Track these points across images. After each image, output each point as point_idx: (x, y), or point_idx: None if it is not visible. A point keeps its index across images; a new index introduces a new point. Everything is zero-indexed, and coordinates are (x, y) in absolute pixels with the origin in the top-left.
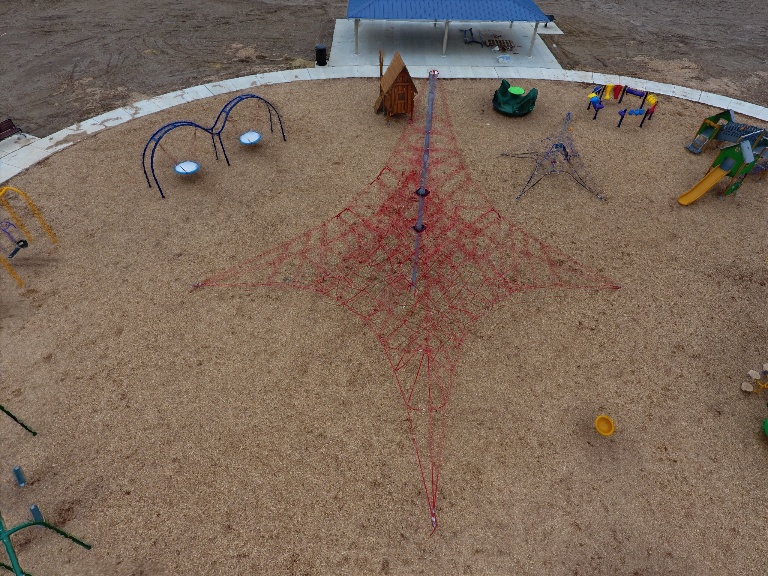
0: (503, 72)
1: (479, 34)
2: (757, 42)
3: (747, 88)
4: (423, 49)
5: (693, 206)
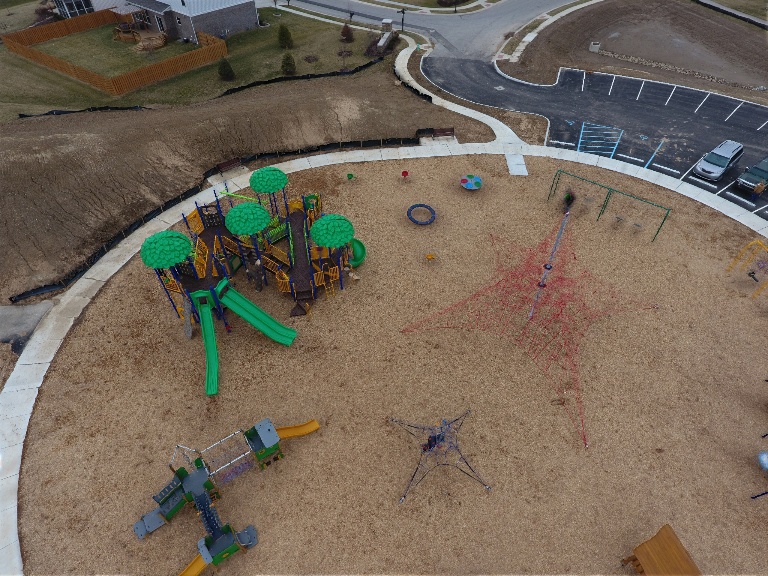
0: None
1: None
2: None
3: None
4: None
5: None
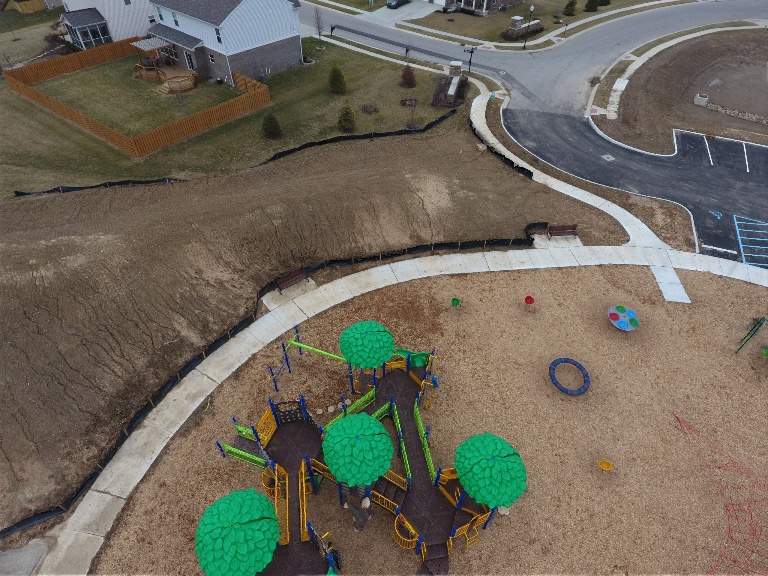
0: None
1: None
2: None
3: None
4: None
5: None
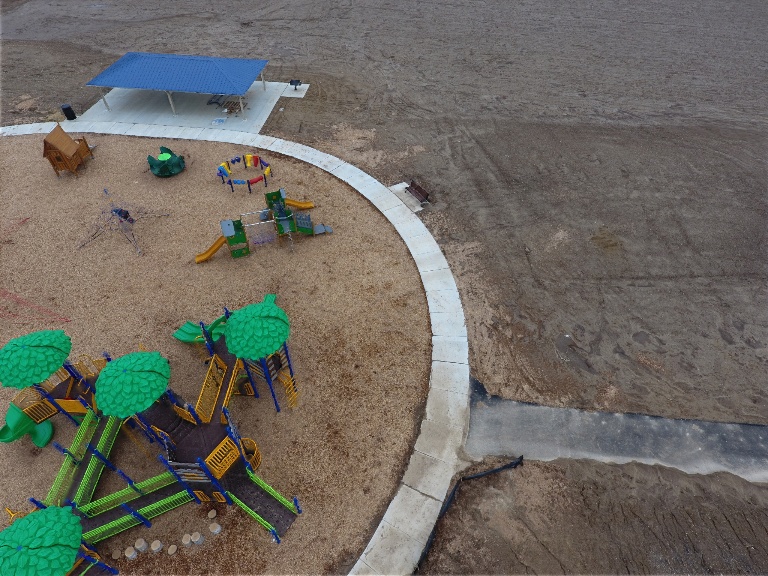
0: (205, 134)
1: (230, 95)
2: (467, 114)
3: (387, 162)
4: (166, 108)
5: (205, 264)
